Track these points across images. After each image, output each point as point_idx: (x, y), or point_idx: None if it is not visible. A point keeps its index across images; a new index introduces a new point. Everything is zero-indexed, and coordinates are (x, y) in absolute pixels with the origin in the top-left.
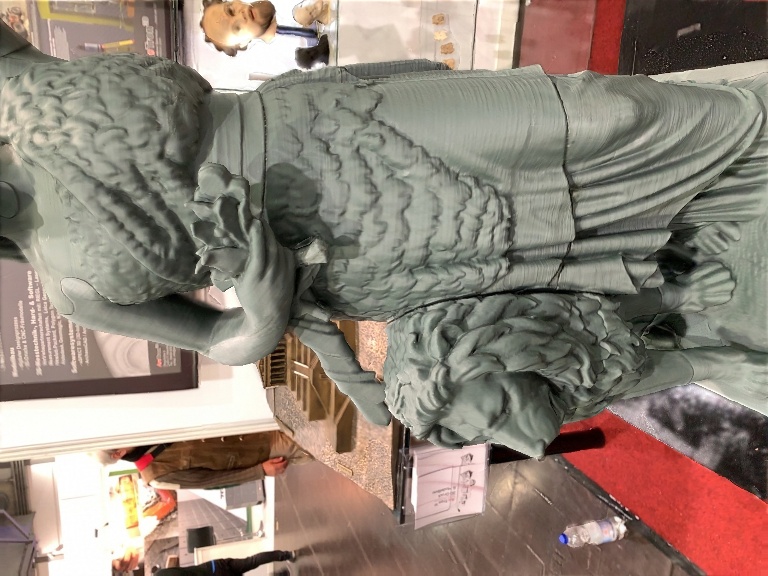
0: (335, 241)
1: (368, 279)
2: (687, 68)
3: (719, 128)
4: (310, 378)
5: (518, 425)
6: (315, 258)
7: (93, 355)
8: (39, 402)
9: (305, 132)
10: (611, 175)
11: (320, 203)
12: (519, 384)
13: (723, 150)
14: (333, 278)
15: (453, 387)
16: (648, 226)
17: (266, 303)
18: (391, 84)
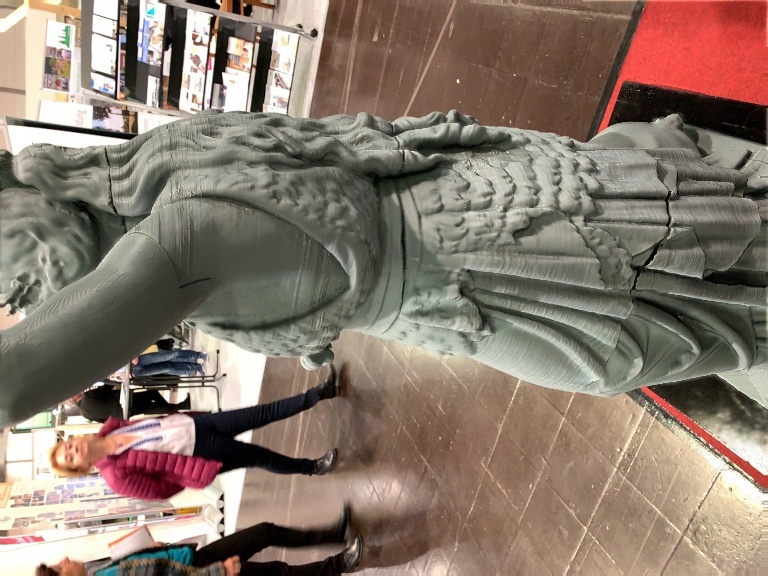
0: None
1: None
2: None
3: None
4: None
5: None
6: None
7: None
8: None
9: None
10: None
11: None
12: None
13: None
14: None
15: None
16: None
17: None
18: (497, 346)
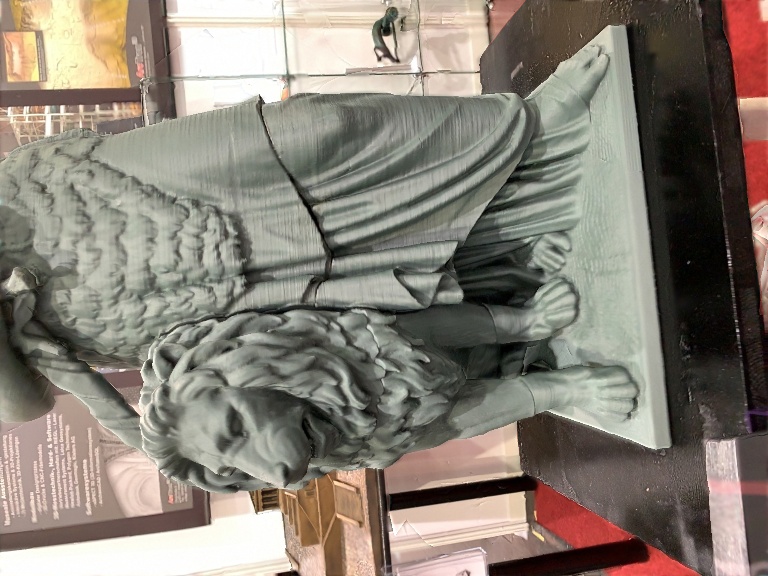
0: (53, 272)
1: (95, 308)
2: None
3: (477, 130)
4: (297, 497)
5: (255, 448)
6: (16, 285)
7: (106, 495)
8: (57, 548)
9: (24, 178)
10: (355, 186)
11: (34, 238)
12: (251, 401)
13: (483, 149)
14: (61, 311)
15: (173, 408)
16: (438, 240)
17: None
18: None
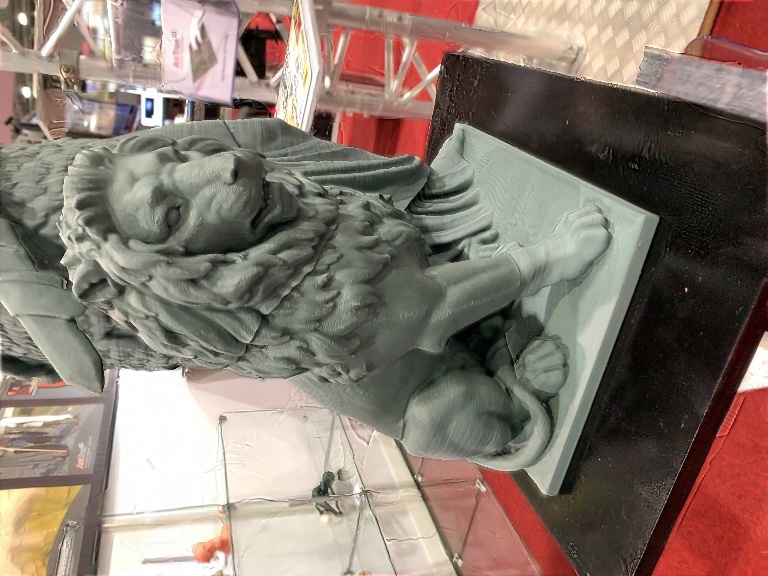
0: (11, 157)
1: (43, 174)
2: None
3: None
4: None
5: None
6: None
7: None
8: None
9: None
10: None
11: None
12: None
13: None
14: (5, 178)
15: None
16: None
17: None
18: None
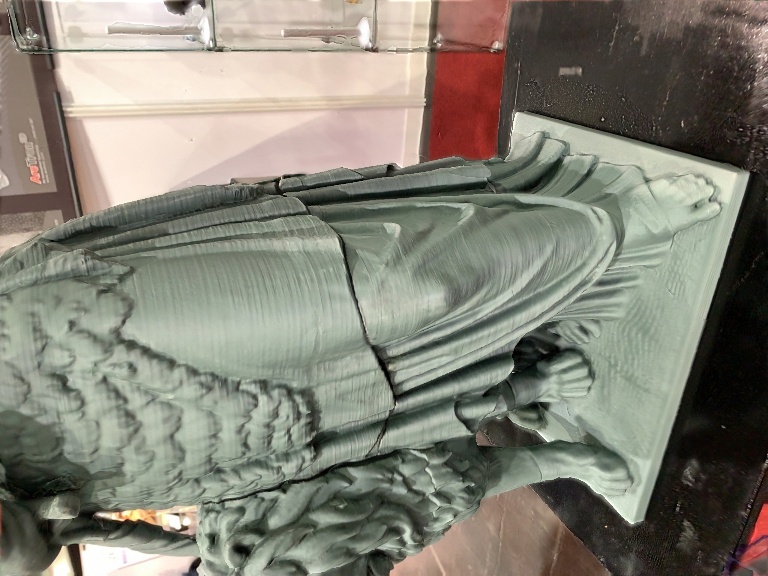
0: (92, 476)
1: (145, 497)
2: (567, 116)
3: (565, 264)
4: None
5: None
6: (60, 517)
7: None
8: None
9: (31, 368)
10: (434, 339)
11: (63, 446)
12: None
13: (568, 290)
14: (102, 502)
15: None
16: (491, 354)
17: (5, 573)
18: (150, 277)
